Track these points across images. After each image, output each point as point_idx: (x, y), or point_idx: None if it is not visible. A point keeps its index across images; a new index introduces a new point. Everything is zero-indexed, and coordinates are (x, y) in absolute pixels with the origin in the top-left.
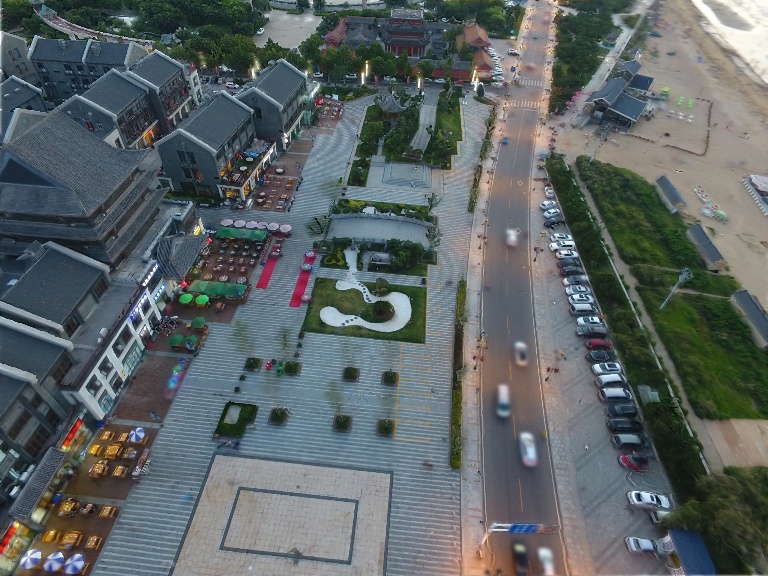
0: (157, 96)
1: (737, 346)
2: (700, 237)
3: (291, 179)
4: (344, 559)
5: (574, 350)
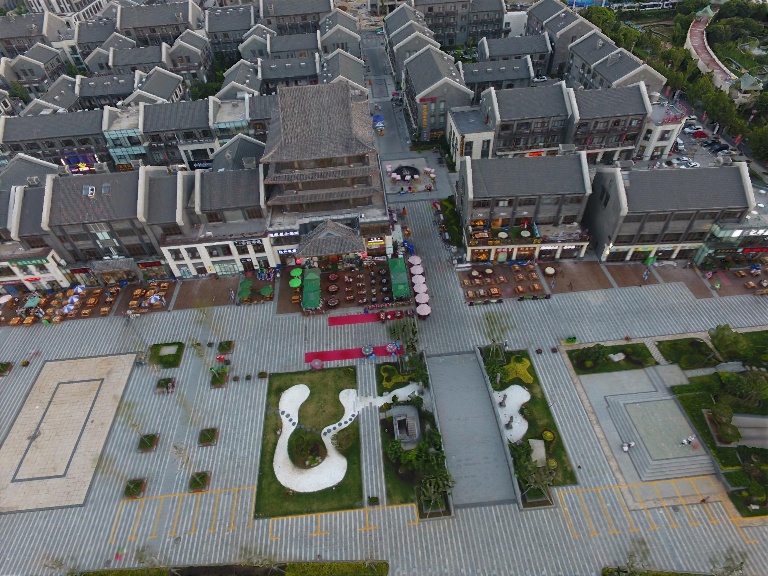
0: (573, 125)
1: None
2: None
3: (536, 286)
4: (17, 476)
5: None
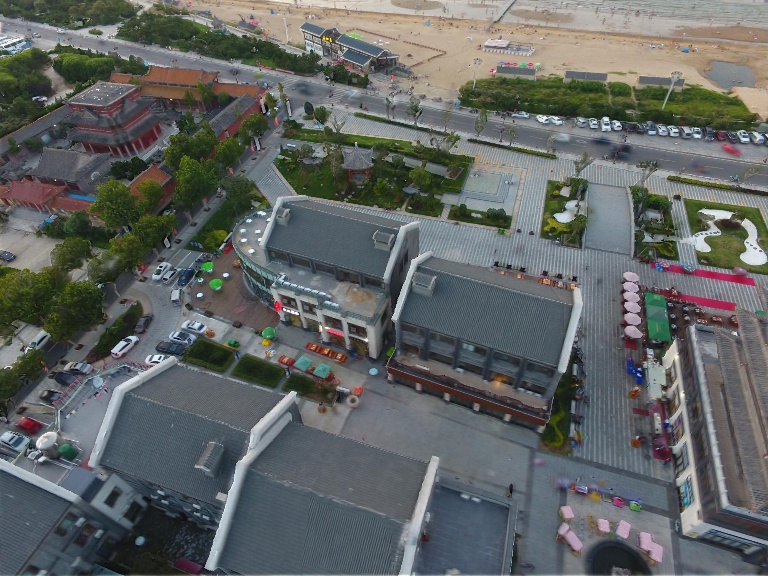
0: (296, 408)
1: (687, 96)
2: (579, 76)
3: None
4: None
5: (727, 146)
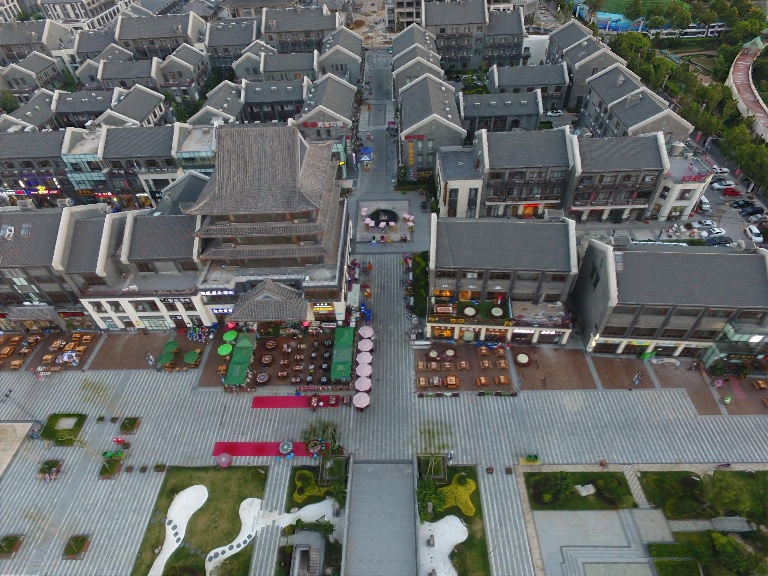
0: (574, 178)
1: None
2: None
3: (502, 379)
4: None
5: None
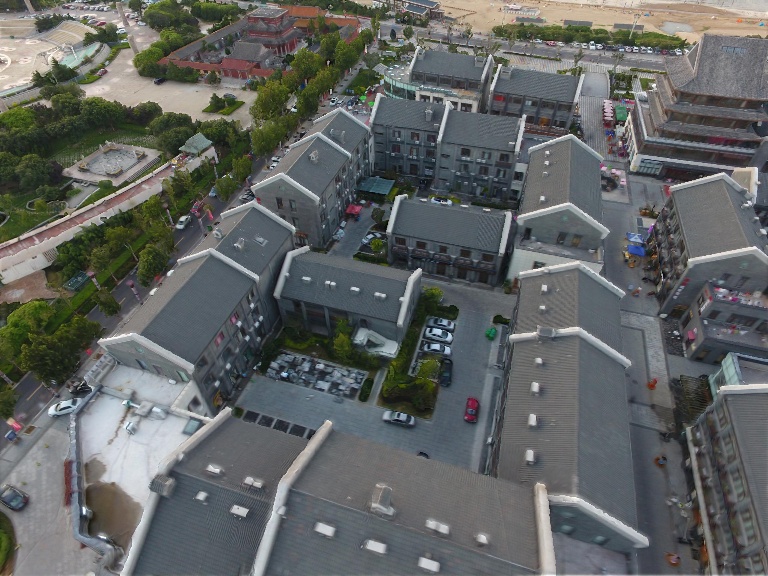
0: None
1: None
2: (573, 23)
3: None
4: None
5: None
